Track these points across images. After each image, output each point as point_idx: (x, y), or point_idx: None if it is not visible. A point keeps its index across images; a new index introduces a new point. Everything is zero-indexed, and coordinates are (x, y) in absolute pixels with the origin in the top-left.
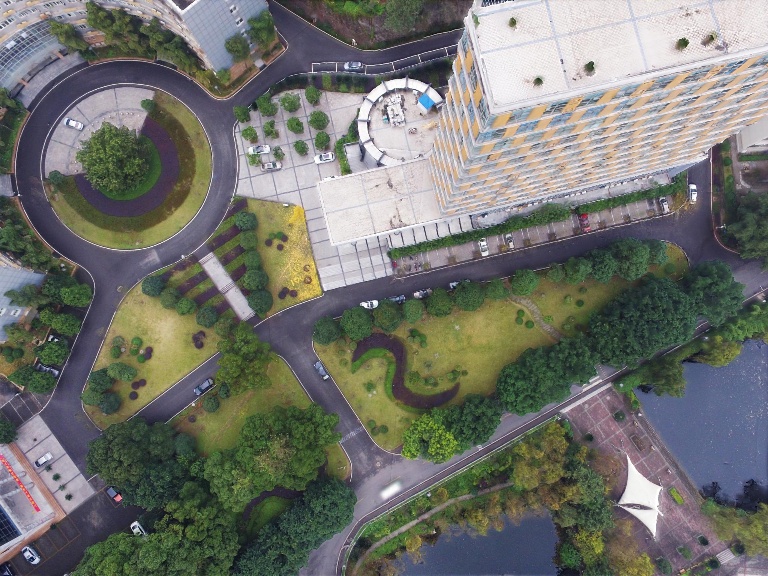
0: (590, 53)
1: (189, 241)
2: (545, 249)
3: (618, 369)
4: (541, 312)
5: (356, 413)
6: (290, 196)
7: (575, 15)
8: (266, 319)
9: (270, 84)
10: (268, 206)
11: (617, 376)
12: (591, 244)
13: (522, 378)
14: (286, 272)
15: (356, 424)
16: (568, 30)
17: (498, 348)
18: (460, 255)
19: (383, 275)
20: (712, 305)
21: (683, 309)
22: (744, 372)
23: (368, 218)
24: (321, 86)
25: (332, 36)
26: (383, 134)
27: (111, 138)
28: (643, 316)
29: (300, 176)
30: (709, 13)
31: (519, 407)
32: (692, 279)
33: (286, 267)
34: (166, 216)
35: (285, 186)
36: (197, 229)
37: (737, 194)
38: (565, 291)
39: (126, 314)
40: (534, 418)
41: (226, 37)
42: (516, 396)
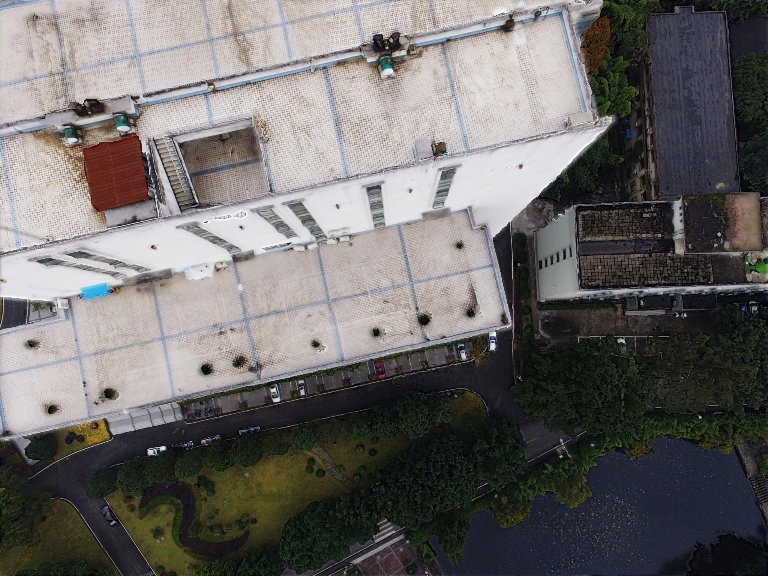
0: (114, 375)
1: None
2: (339, 395)
3: (403, 526)
4: (333, 461)
5: (146, 558)
6: None
7: (102, 333)
8: (54, 463)
9: None
10: None
11: (409, 528)
12: (386, 391)
13: (300, 536)
14: None
15: (146, 569)
16: (94, 349)
17: (288, 496)
18: (252, 400)
19: (172, 420)
20: (490, 471)
21: (459, 474)
22: (546, 524)
23: None
24: None
25: None
26: None
27: None
28: (418, 481)
29: None
30: (245, 331)
31: (294, 567)
32: (477, 438)
33: None
34: None
35: None
36: None
37: (535, 344)
38: (358, 440)
39: None
40: (325, 568)
41: None
42: (292, 555)
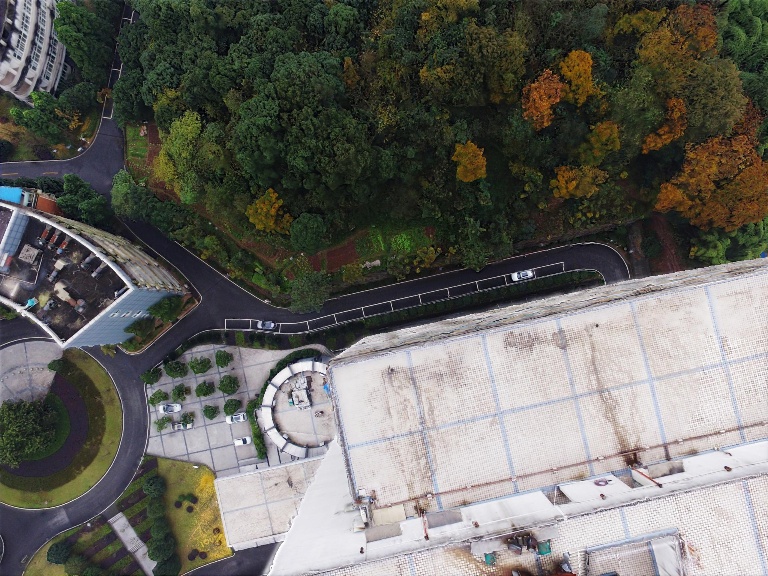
0: None
1: (98, 500)
2: None
3: None
4: None
5: None
6: (201, 456)
7: None
8: None
9: (182, 340)
10: (178, 466)
11: None
12: None
13: None
14: (196, 534)
15: None
16: None
17: None
18: None
19: None
20: None
21: None
22: None
23: (266, 518)
24: (234, 343)
25: (246, 291)
26: (289, 416)
27: (10, 421)
28: None
29: (212, 435)
30: None
31: None
32: None
33: (196, 529)
34: (75, 475)
35: (196, 445)
36: (107, 488)
37: None
38: None
39: (34, 574)
40: None
41: (124, 327)
42: None
